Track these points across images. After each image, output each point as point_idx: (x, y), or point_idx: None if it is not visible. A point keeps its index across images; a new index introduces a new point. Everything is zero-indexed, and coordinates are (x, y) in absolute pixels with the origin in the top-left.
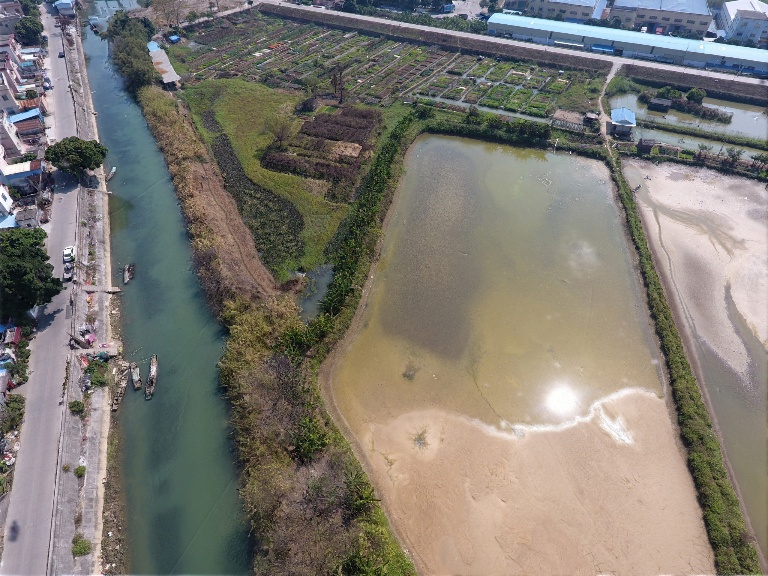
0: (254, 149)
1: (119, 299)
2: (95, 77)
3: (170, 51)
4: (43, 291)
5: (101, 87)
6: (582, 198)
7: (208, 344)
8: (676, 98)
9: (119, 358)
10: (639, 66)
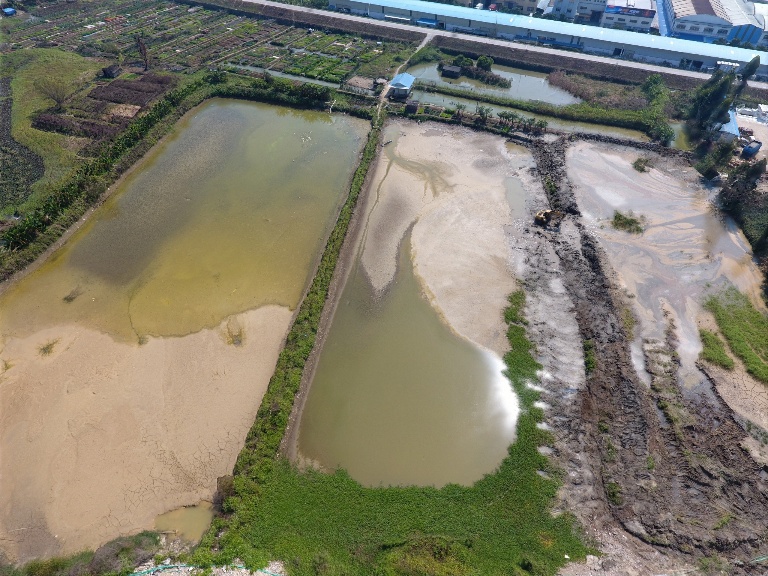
0: (32, 111)
1: None
2: None
3: None
4: None
5: None
6: (330, 152)
7: None
8: (467, 65)
9: None
10: (449, 37)
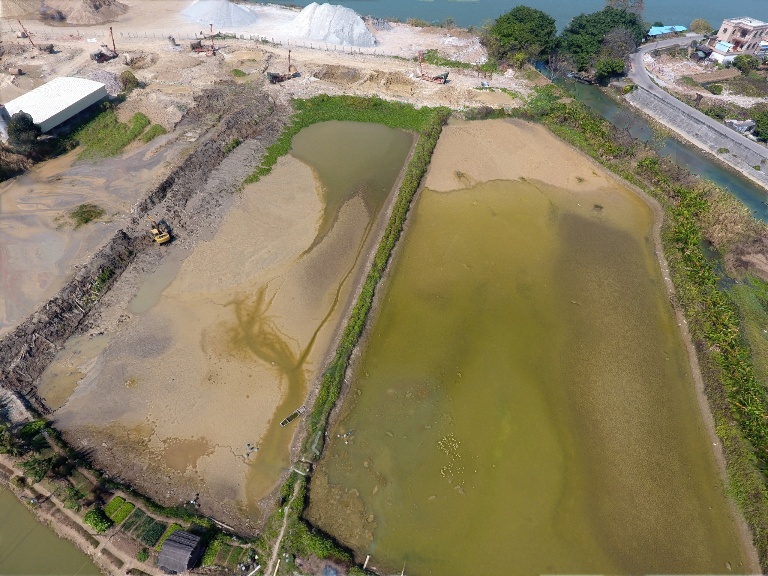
0: None
1: None
2: None
3: None
4: None
5: None
6: (401, 396)
7: None
8: None
9: None
10: None
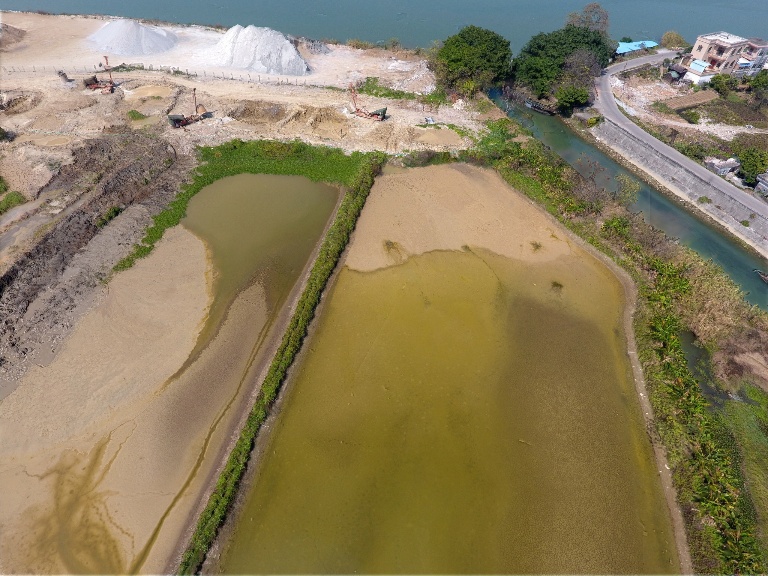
0: None
1: None
2: None
3: None
4: None
5: None
6: None
7: None
8: None
9: None
10: None
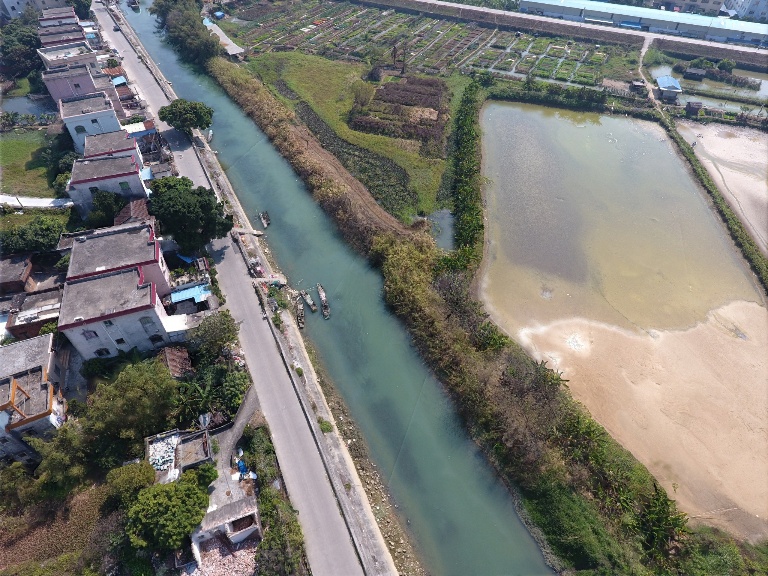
0: (338, 114)
1: (265, 241)
2: (153, 50)
3: (219, 26)
4: (221, 226)
5: (164, 59)
6: (648, 153)
7: (362, 275)
8: (709, 68)
9: (288, 287)
10: (669, 40)
